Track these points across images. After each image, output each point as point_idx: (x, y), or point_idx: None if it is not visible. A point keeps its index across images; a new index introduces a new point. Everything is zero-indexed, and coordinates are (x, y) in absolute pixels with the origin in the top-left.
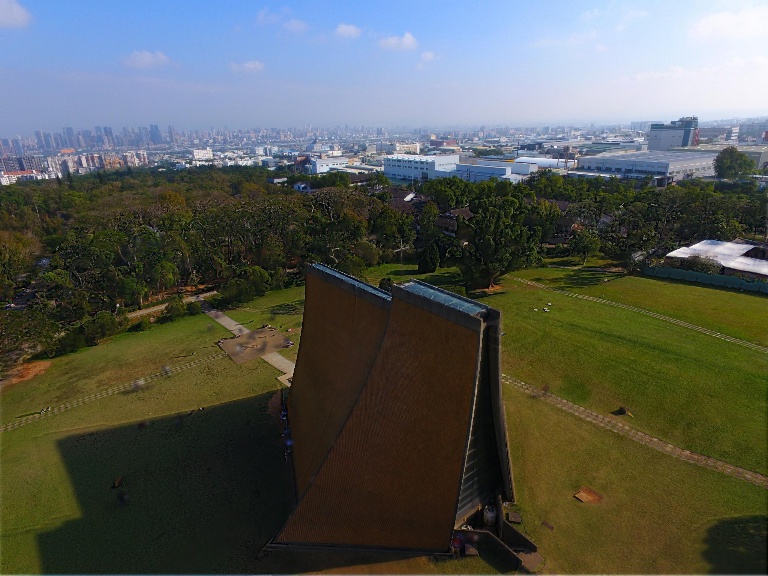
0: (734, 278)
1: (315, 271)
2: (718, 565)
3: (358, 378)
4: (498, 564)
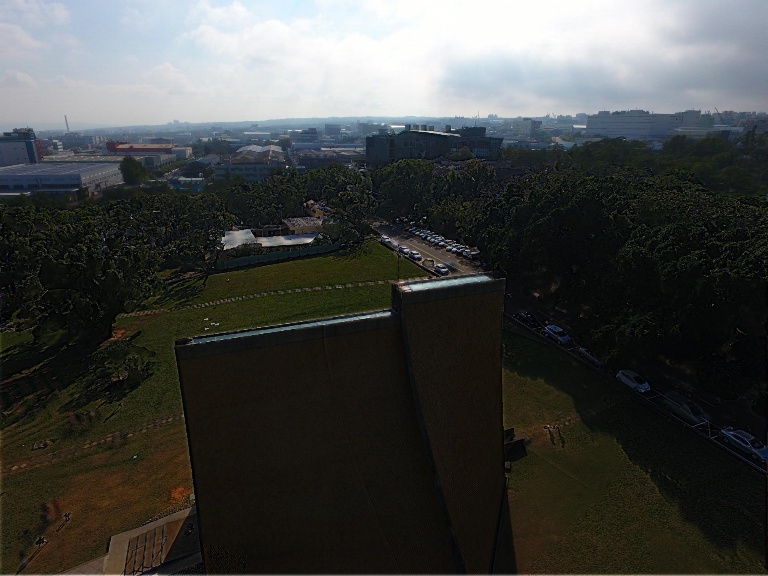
0: (282, 252)
1: (214, 347)
2: (530, 372)
3: (379, 419)
4: (519, 455)
